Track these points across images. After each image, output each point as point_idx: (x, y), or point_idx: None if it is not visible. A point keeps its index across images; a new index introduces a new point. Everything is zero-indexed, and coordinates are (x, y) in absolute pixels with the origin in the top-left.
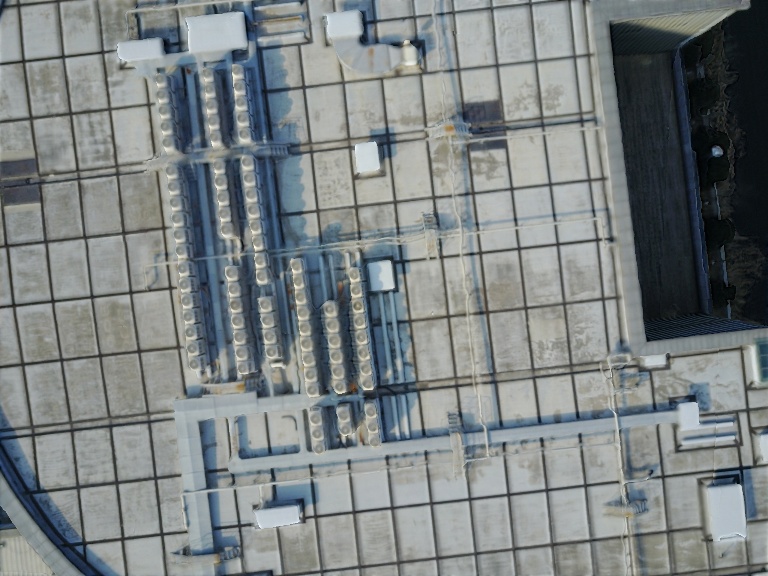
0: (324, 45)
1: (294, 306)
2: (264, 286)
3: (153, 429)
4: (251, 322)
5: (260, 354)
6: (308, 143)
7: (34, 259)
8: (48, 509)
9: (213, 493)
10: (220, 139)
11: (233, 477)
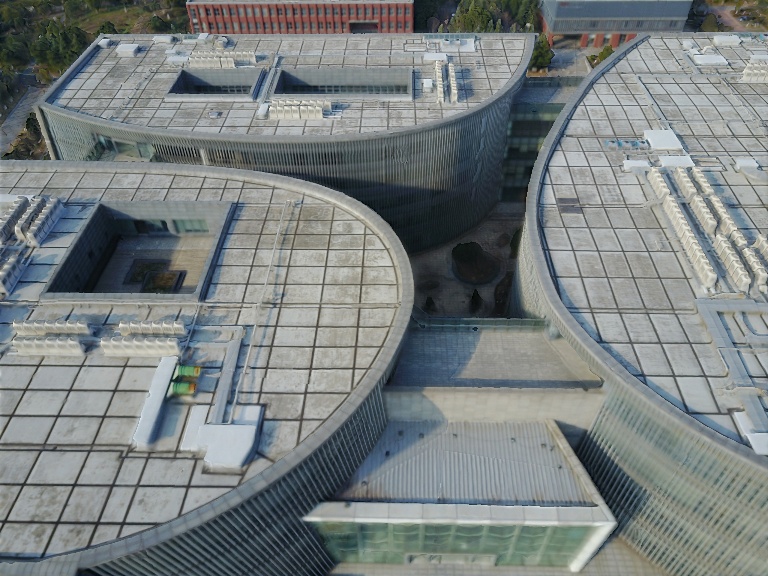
0: (734, 172)
1: (763, 262)
2: (745, 244)
3: (679, 317)
4: (742, 259)
5: (753, 277)
6: (739, 205)
7: (583, 233)
8: (611, 352)
9: (740, 353)
10: (696, 189)
11: (751, 348)
